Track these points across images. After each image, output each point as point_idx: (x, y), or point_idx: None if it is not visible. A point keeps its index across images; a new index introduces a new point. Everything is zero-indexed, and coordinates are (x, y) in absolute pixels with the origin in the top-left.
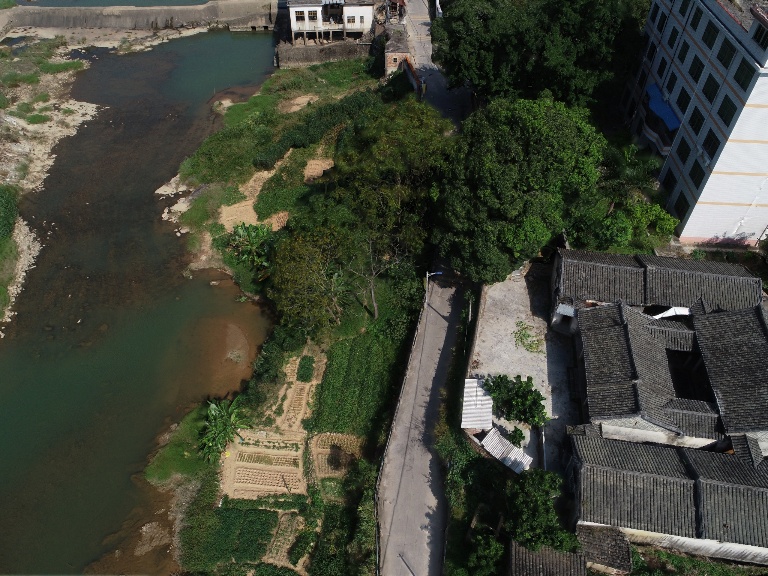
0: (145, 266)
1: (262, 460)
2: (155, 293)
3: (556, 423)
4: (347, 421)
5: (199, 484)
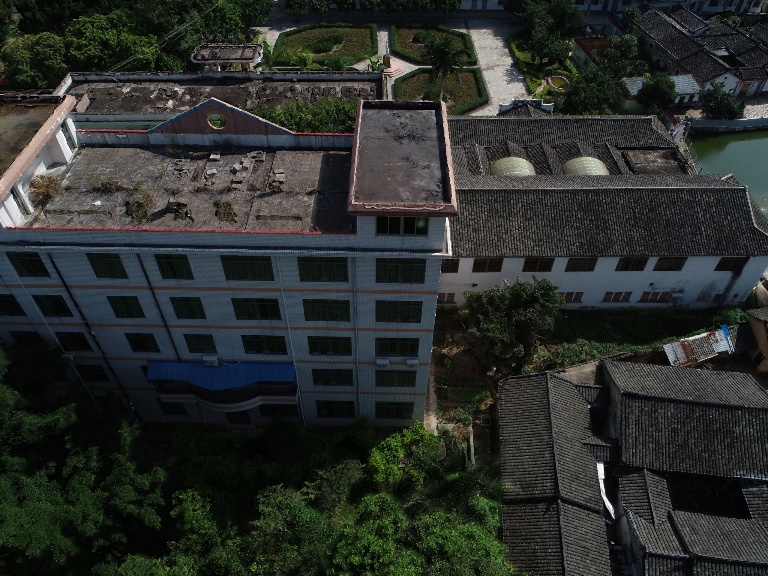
0: None
1: None
2: None
3: None
4: None
5: None
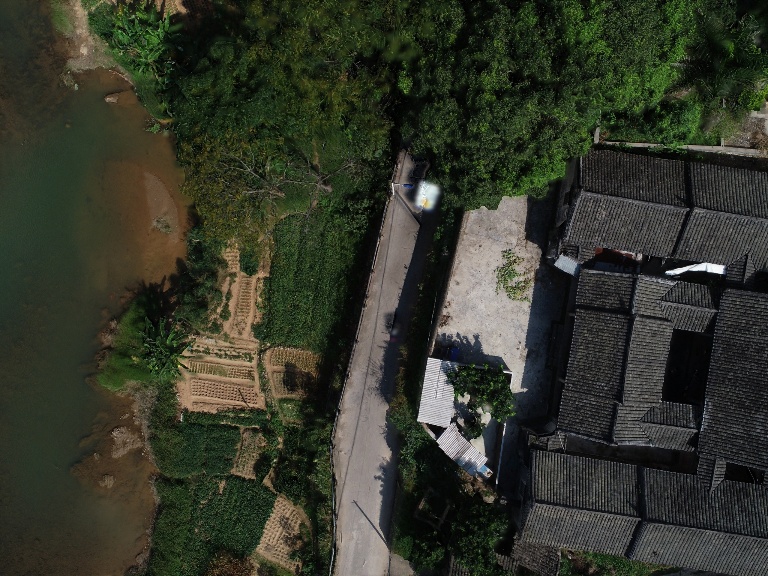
0: (6, 64)
1: (215, 371)
2: (35, 116)
3: (523, 398)
4: (301, 334)
5: (156, 390)
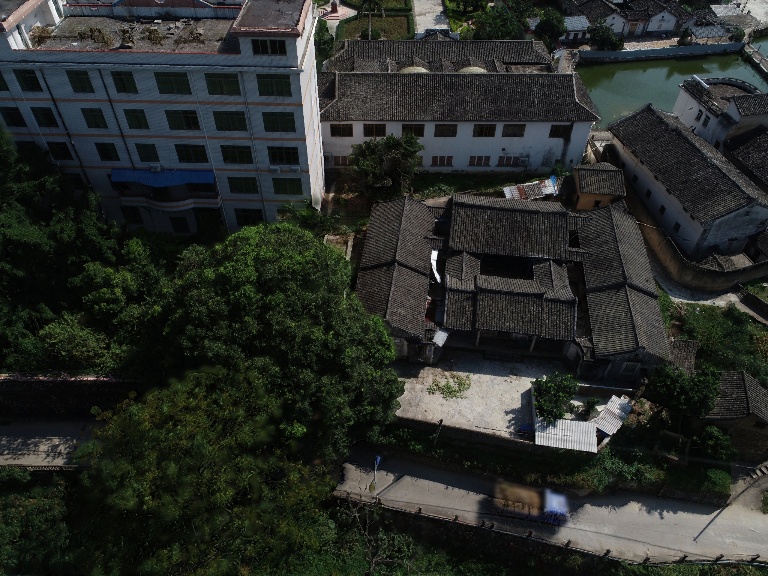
0: None
1: None
2: None
3: None
4: None
5: None
